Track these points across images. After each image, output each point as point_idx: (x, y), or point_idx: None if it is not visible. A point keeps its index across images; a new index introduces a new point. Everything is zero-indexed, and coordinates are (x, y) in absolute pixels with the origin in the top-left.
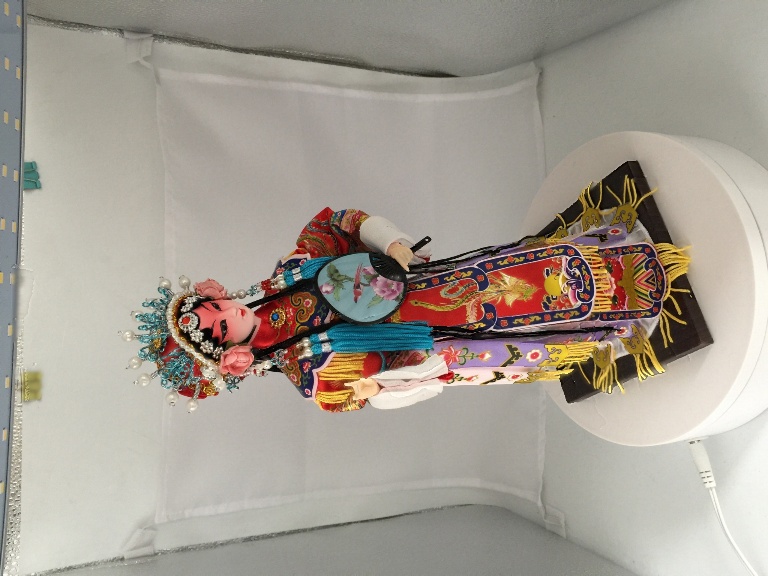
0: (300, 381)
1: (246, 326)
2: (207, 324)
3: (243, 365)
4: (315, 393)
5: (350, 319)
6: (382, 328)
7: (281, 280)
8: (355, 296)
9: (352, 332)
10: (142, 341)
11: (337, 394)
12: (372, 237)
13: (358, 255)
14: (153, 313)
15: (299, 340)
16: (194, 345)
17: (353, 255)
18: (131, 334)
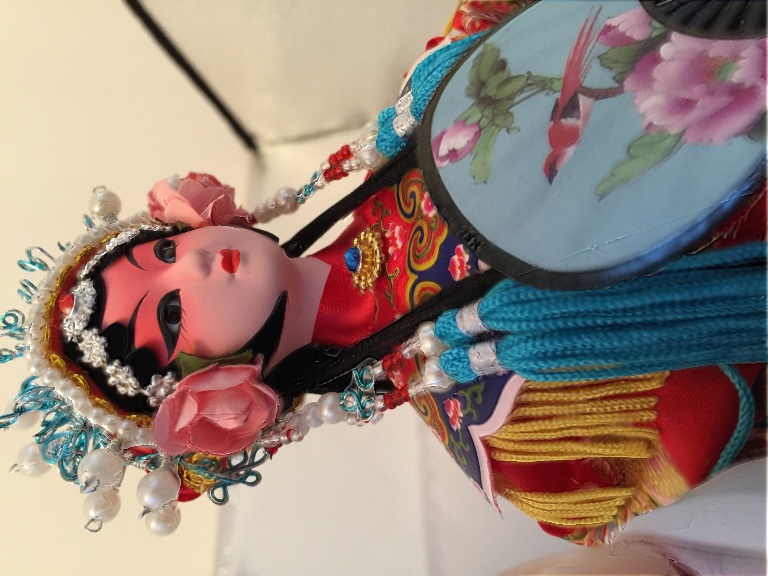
0: (450, 451)
1: (242, 301)
2: (120, 310)
3: (232, 425)
4: (491, 498)
5: (513, 262)
6: (716, 271)
7: (369, 142)
8: (550, 152)
9: (571, 302)
10: None
11: (574, 499)
12: None
13: None
14: None
15: (412, 331)
16: (92, 374)
17: None
18: None
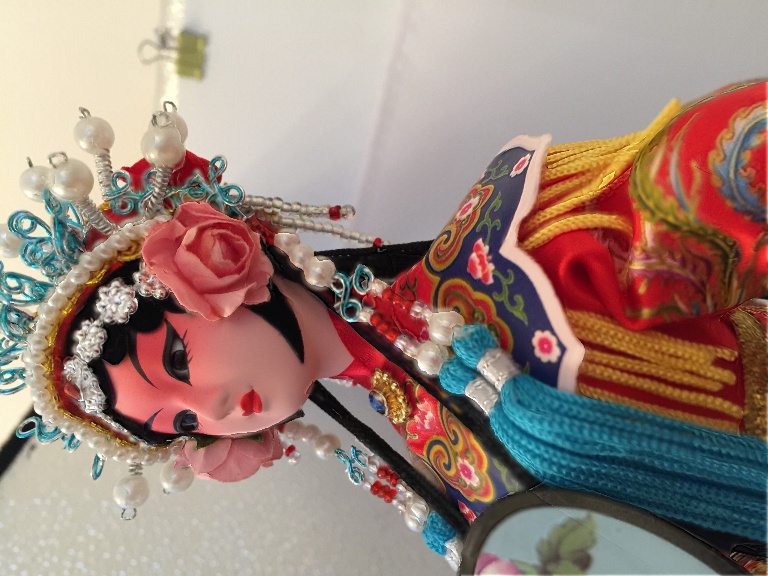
0: None
1: (260, 427)
2: (134, 412)
3: None
4: None
5: None
6: None
7: (434, 349)
8: None
9: None
10: (29, 292)
11: None
12: None
13: None
14: (4, 308)
15: None
16: None
17: (701, 570)
18: (12, 251)
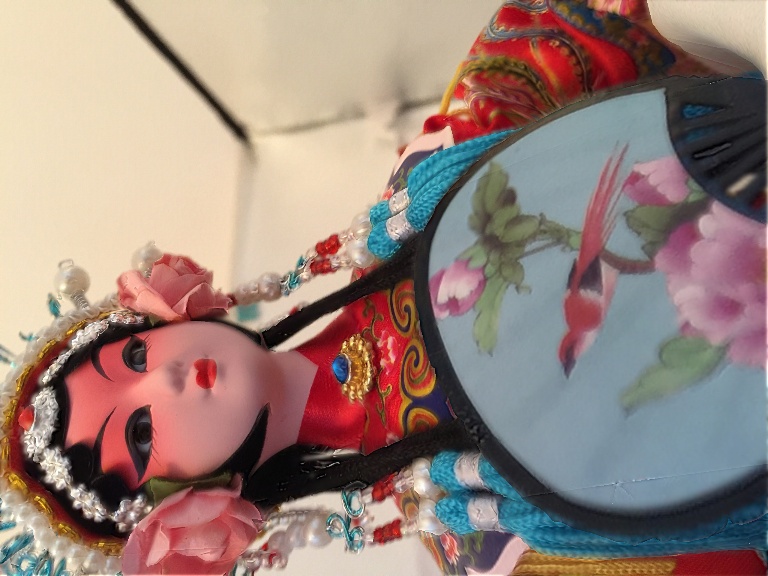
0: None
1: (219, 420)
2: (85, 428)
3: (208, 558)
4: None
5: (523, 475)
6: None
7: (359, 237)
8: (567, 333)
9: None
10: None
11: None
12: (695, 4)
13: (612, 106)
14: None
15: (405, 463)
16: (56, 495)
17: (589, 110)
18: None
